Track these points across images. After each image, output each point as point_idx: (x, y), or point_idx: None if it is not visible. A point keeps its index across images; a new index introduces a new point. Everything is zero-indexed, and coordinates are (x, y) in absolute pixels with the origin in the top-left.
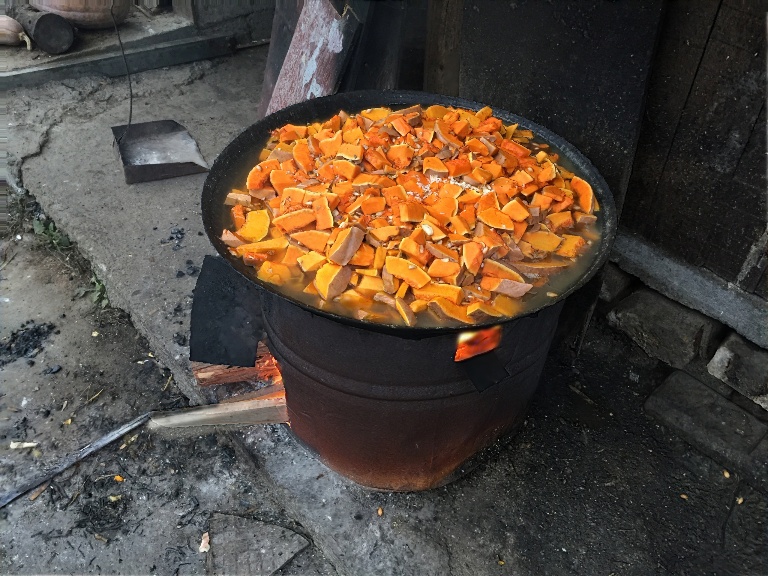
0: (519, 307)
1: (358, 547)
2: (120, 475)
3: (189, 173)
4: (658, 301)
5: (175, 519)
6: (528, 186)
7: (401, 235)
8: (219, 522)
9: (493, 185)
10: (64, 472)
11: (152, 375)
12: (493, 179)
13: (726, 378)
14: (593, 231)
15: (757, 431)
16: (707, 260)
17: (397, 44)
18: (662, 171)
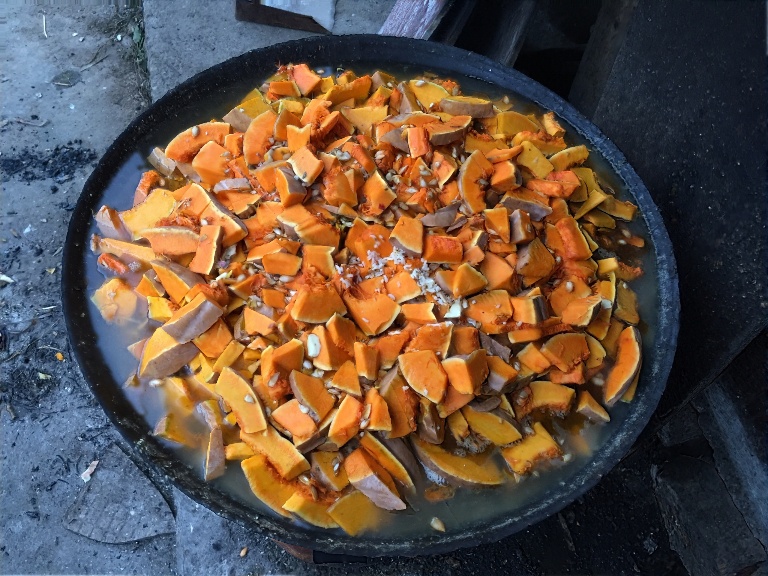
0: (376, 522)
1: None
2: (63, 353)
3: (307, 29)
4: (723, 492)
5: (82, 428)
6: (528, 326)
7: (277, 335)
8: (113, 457)
9: (473, 303)
10: (19, 324)
11: None
12: (486, 289)
13: None
14: (590, 437)
15: None
16: None
17: None
18: None
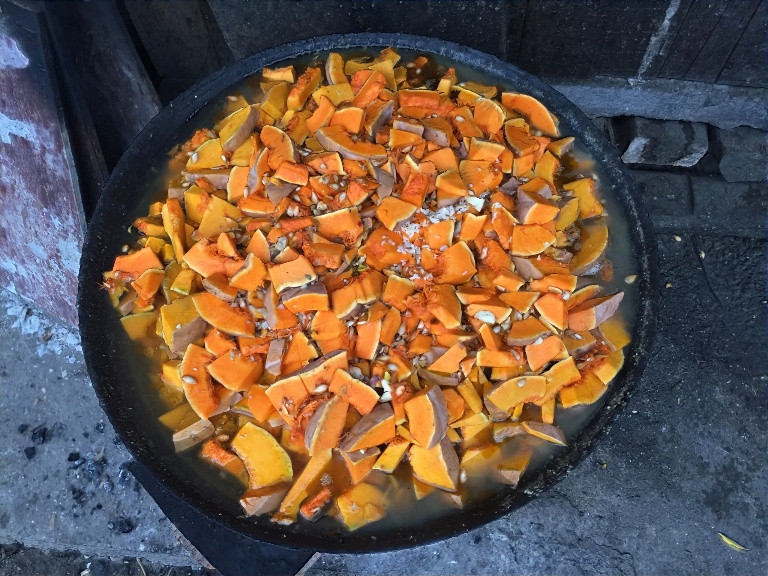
0: (621, 322)
1: (500, 564)
2: None
3: None
4: None
5: None
6: (499, 156)
7: None
8: None
9: (472, 187)
10: None
11: (114, 574)
12: None
13: (643, 160)
14: (581, 157)
15: (681, 186)
16: (601, 69)
17: (105, 9)
18: (527, 2)
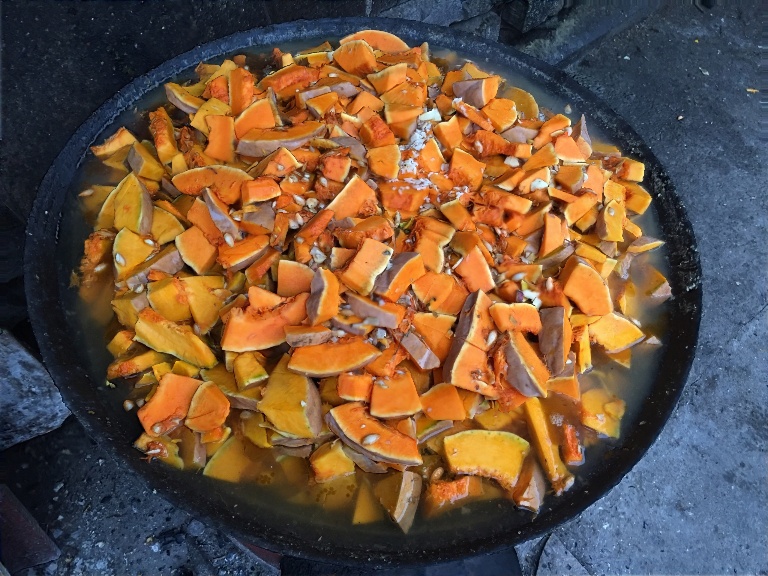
0: (595, 140)
1: None
2: None
3: None
4: None
5: None
6: None
7: None
8: None
9: None
10: None
11: None
12: None
13: None
14: (442, 54)
15: None
16: None
17: None
18: None
